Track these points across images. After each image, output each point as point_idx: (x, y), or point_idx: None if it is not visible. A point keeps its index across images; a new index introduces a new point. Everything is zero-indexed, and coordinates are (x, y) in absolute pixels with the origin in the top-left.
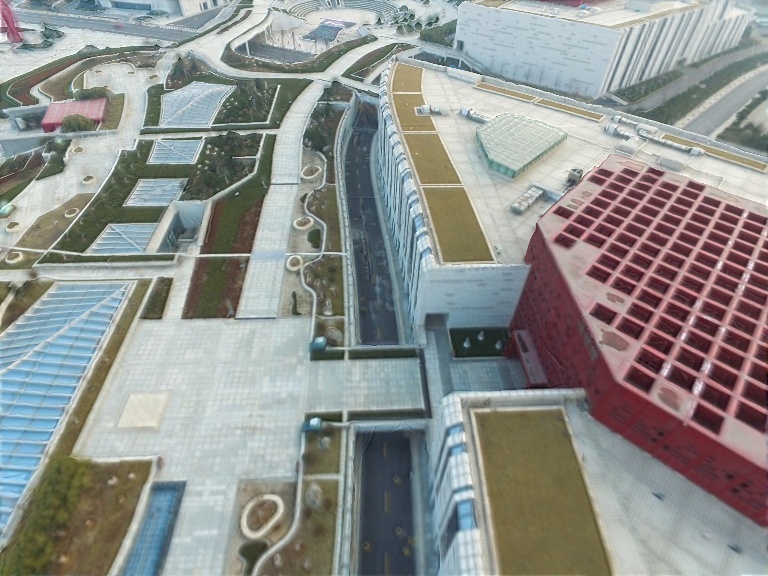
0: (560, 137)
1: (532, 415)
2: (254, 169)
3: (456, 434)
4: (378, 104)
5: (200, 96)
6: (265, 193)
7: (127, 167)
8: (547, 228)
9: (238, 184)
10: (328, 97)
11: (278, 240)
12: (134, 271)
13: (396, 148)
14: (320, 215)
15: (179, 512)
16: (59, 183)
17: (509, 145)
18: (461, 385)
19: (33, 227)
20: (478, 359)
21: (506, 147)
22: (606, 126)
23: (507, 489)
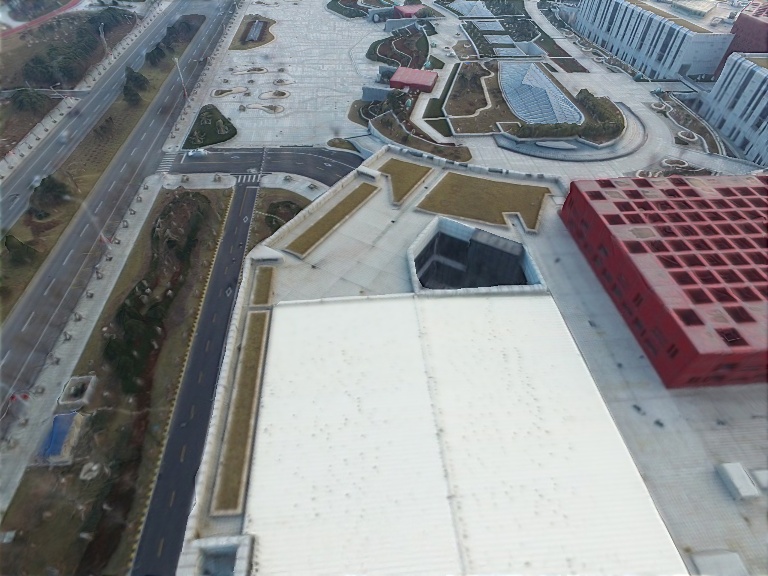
0: (716, 4)
1: (762, 58)
2: (539, 32)
3: (742, 58)
4: (571, 12)
5: (477, 3)
6: (554, 41)
7: (473, 30)
8: (747, 13)
9: (538, 37)
10: (544, 7)
11: (581, 54)
12: (527, 61)
13: (637, 8)
14: (591, 47)
15: (628, 106)
16: (442, 37)
17: (695, 5)
18: (704, 87)
19: (455, 50)
20: (706, 82)
21: (695, 5)
22: (733, 3)
23: (765, 66)
